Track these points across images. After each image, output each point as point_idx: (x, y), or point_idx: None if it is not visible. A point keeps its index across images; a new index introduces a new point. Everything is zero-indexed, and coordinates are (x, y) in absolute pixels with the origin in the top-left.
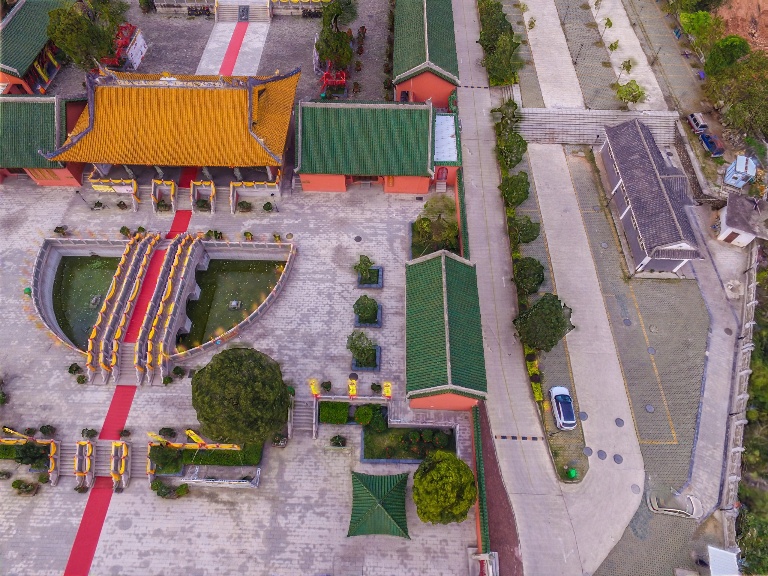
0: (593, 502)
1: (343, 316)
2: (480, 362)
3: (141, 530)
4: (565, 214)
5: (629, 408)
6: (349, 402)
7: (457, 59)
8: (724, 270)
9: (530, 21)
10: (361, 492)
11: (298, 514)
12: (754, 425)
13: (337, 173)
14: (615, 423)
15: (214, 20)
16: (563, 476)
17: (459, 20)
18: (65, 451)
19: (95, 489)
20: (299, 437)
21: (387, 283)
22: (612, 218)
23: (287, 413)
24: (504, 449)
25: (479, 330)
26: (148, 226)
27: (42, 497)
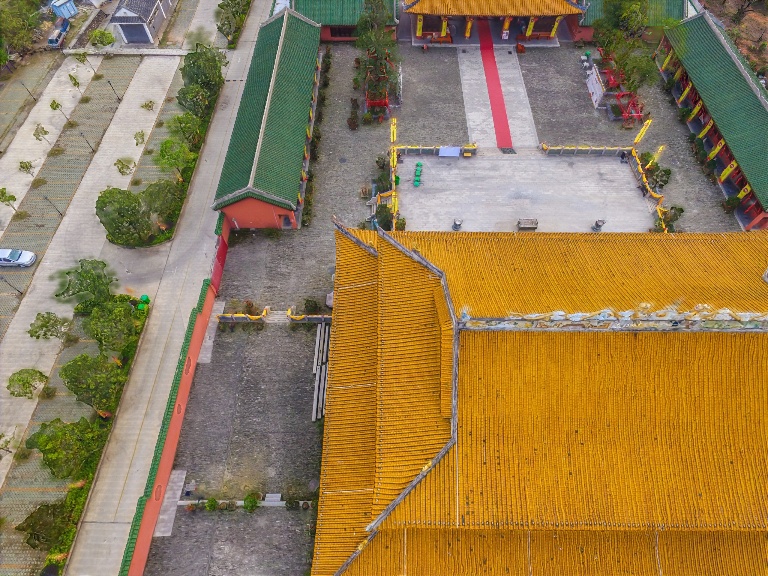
0: None
1: None
2: None
3: None
4: (208, 7)
5: None
6: None
7: None
8: None
9: None
10: None
11: None
12: None
13: None
14: None
15: None
16: None
17: None
18: None
19: None
20: None
21: None
22: (176, 7)
23: None
24: None
25: None
26: None
27: None
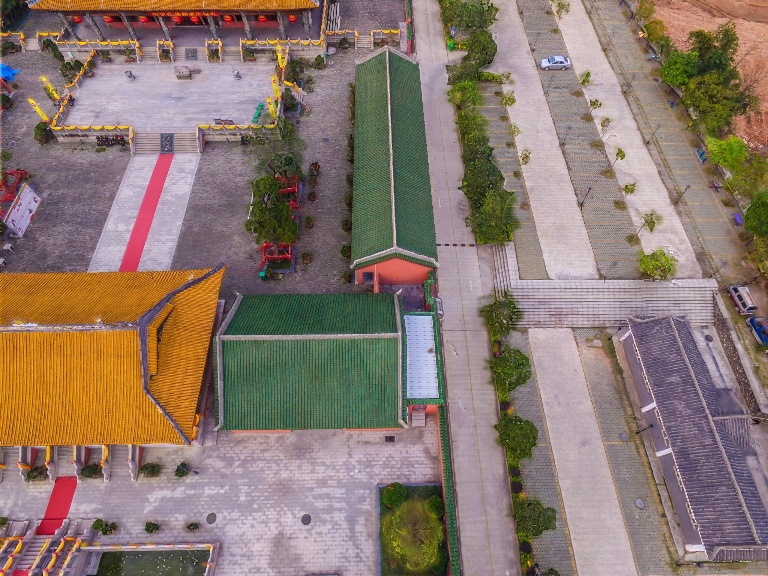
0: None
1: None
2: None
3: None
4: (584, 449)
5: None
6: None
7: (434, 203)
8: None
9: (523, 153)
10: None
11: None
12: None
13: (274, 429)
14: None
15: (130, 152)
16: None
17: (435, 141)
18: None
19: None
20: None
21: None
22: (646, 453)
23: None
24: None
25: None
26: (14, 509)
27: None
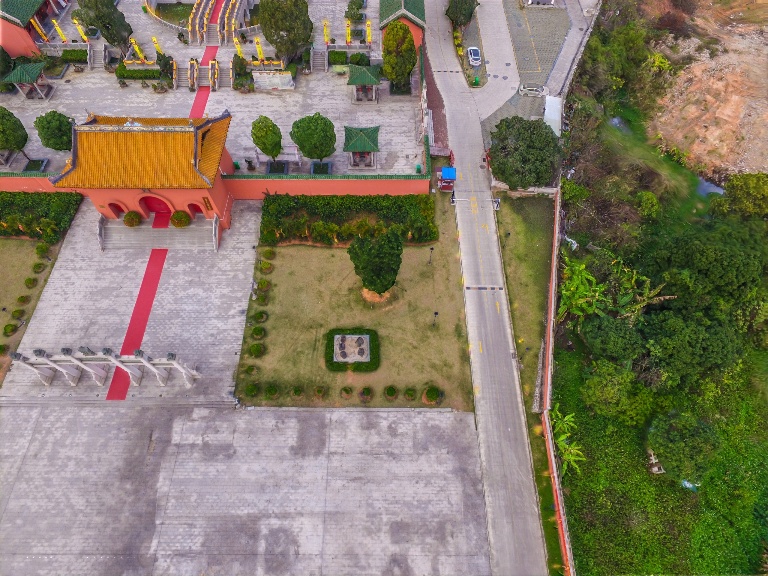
0: (488, 94)
1: (342, 19)
2: (422, 15)
3: (229, 104)
4: None
5: (514, 59)
6: (346, 52)
7: None
8: (585, 4)
9: None
10: (354, 69)
11: (318, 98)
12: (587, 64)
13: None
14: (505, 64)
15: None
16: (472, 84)
17: None
18: (180, 72)
19: (199, 91)
20: (317, 72)
21: (369, 6)
22: None
23: (310, 55)
24: (439, 76)
25: (423, 4)
26: None
27: (169, 94)
